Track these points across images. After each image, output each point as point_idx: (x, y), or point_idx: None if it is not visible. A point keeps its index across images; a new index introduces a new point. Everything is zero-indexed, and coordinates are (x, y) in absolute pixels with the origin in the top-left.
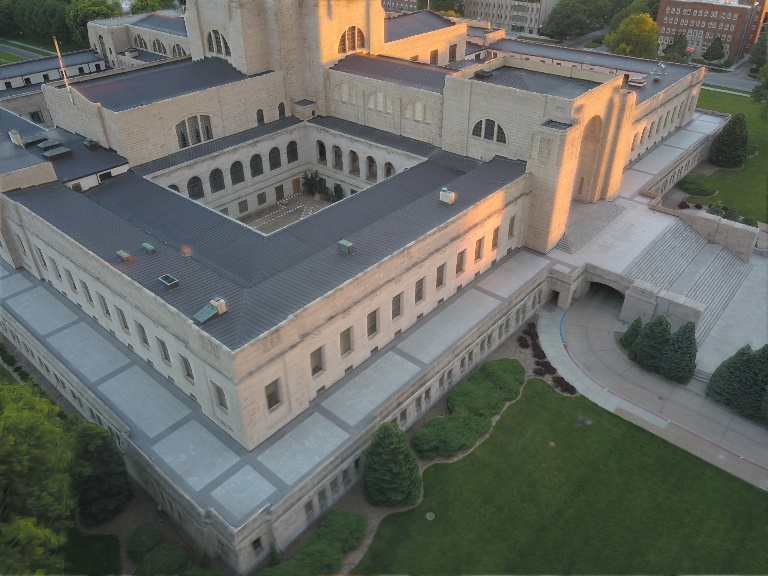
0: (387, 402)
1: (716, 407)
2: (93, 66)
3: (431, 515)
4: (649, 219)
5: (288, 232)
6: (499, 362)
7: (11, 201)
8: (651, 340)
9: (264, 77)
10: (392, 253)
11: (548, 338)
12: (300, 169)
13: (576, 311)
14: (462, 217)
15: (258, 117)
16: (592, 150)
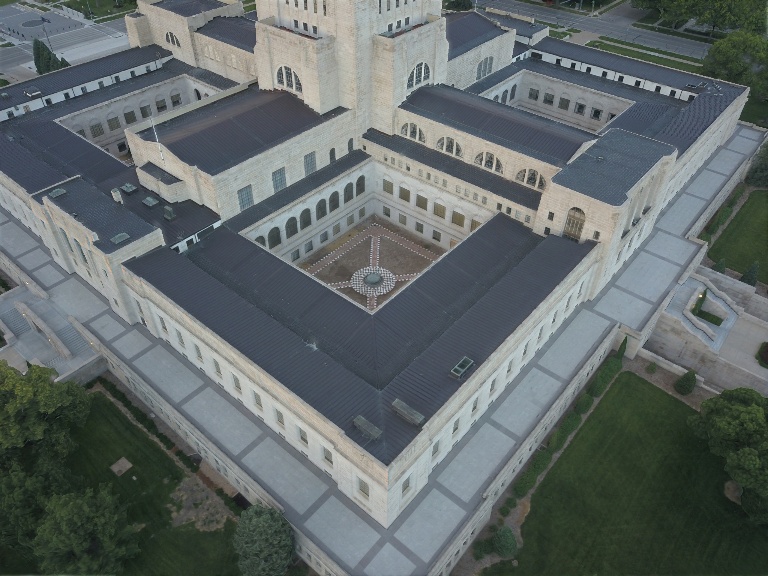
0: None
1: None
2: None
3: None
4: None
5: None
6: None
7: None
8: None
9: None
10: None
11: None
12: None
13: None
14: None
15: None
16: None
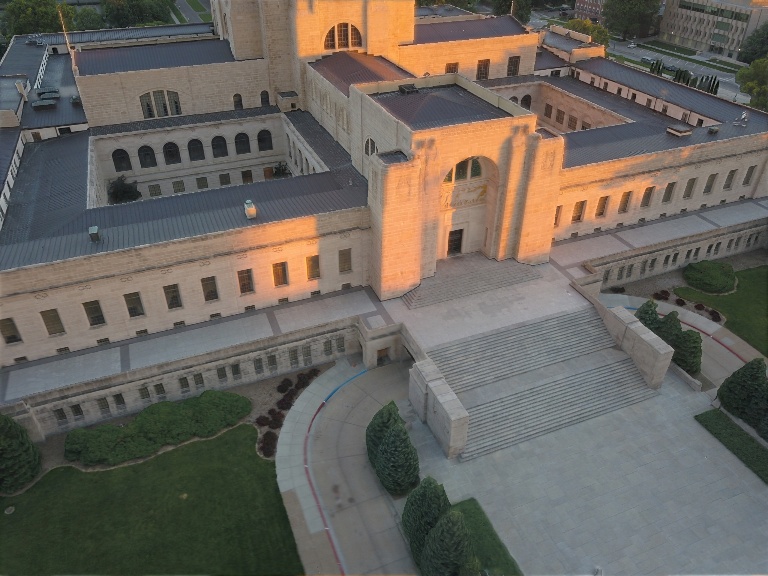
0: (46, 390)
1: (400, 538)
2: None
3: (11, 509)
4: (552, 297)
5: (110, 210)
6: (220, 395)
7: None
8: (373, 430)
9: (243, 63)
10: None
11: (315, 391)
12: (274, 159)
13: (378, 373)
14: (235, 234)
15: (236, 101)
16: (493, 197)
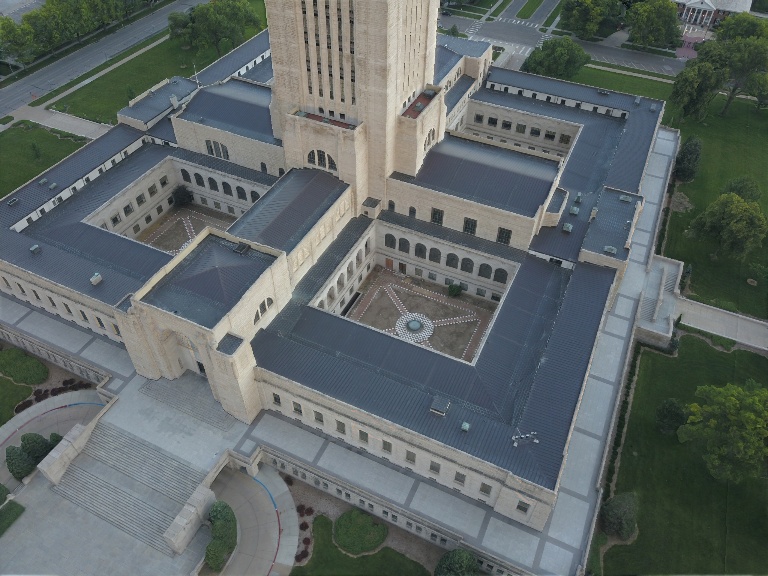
0: None
1: None
2: None
3: None
4: (203, 448)
5: (87, 228)
6: (35, 366)
7: None
8: None
9: (267, 145)
10: (26, 268)
11: (74, 396)
12: None
13: None
14: (70, 291)
15: (263, 167)
16: None
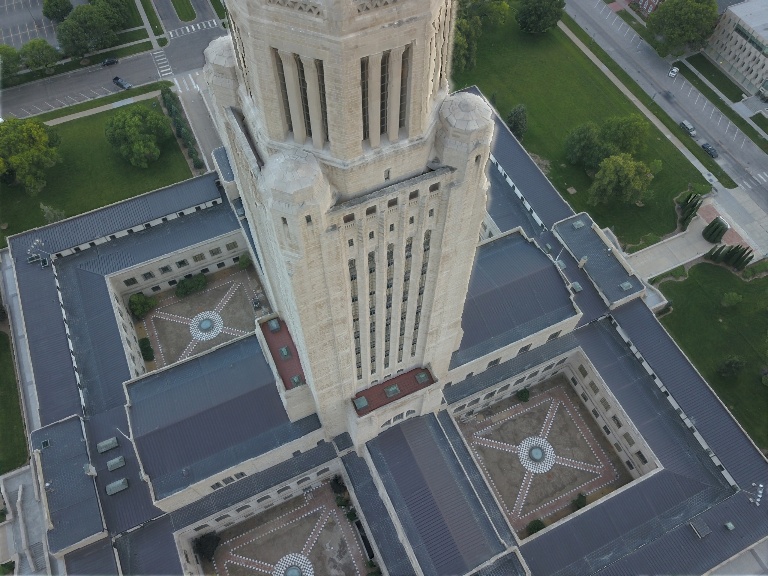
0: None
1: None
2: (210, 203)
3: None
4: None
5: None
6: None
7: None
8: None
9: (302, 439)
10: None
11: None
12: (330, 474)
13: None
14: None
15: (294, 453)
16: None
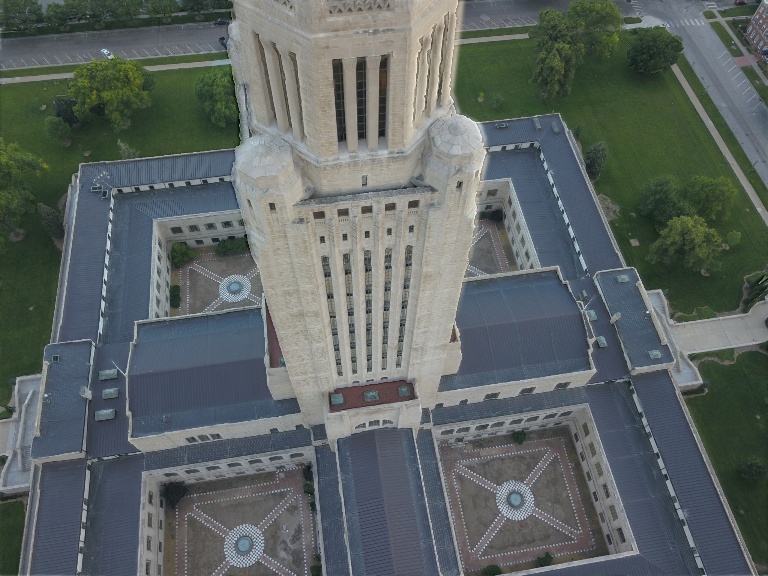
0: None
1: None
2: None
3: None
4: None
5: None
6: None
7: (38, 486)
8: None
9: (279, 418)
10: None
11: None
12: (305, 460)
13: None
14: None
15: None
16: None
